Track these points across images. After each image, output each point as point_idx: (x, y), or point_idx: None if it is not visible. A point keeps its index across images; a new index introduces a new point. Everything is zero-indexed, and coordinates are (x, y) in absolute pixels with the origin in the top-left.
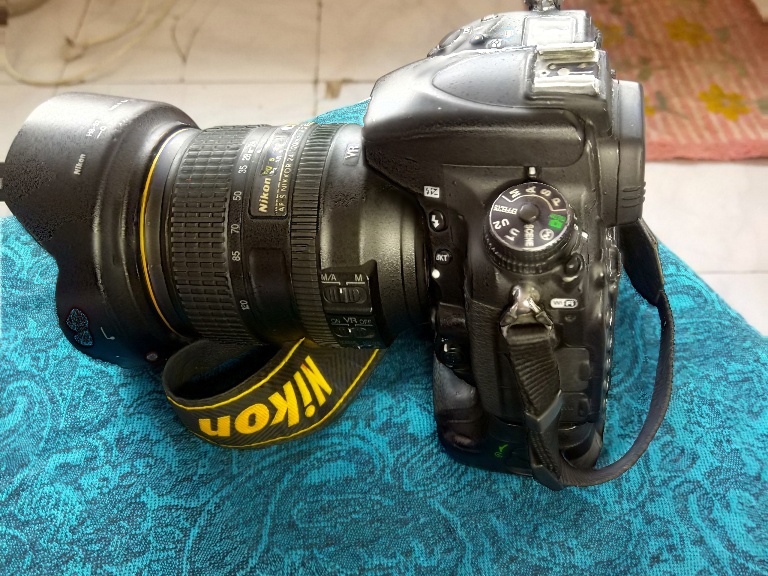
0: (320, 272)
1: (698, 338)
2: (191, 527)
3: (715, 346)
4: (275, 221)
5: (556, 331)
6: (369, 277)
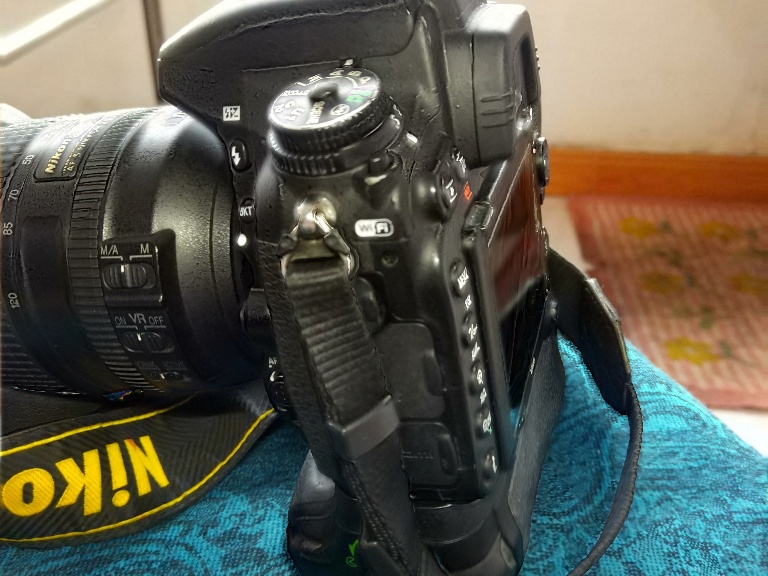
0: (100, 244)
1: (690, 465)
2: None
3: (714, 476)
4: (60, 183)
5: (375, 288)
6: (159, 248)
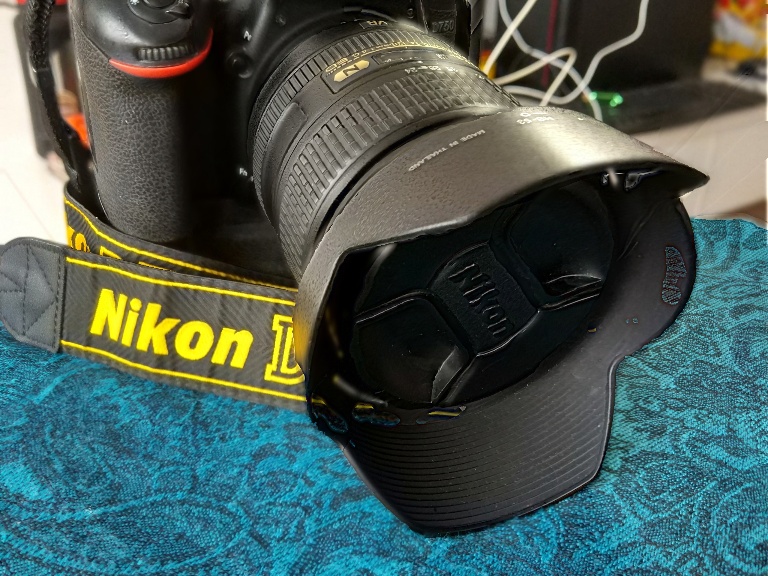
0: None
1: None
2: (649, 349)
3: None
4: None
5: None
6: None
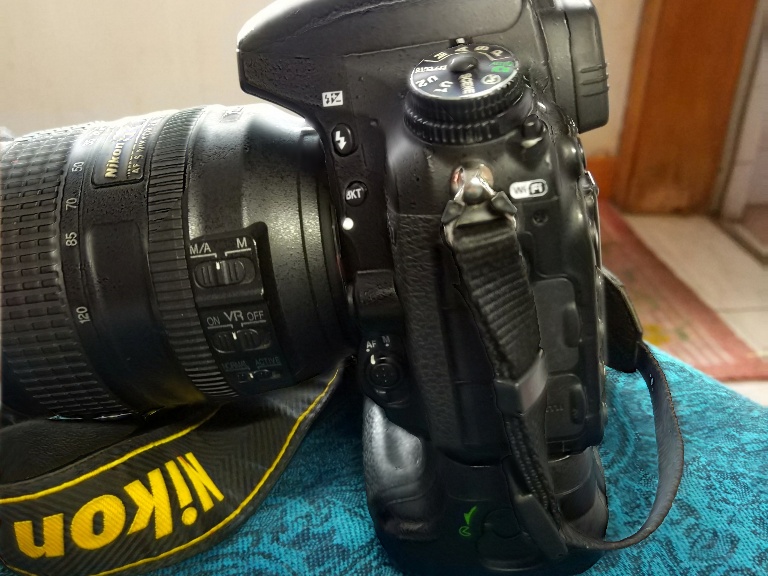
0: (188, 243)
1: (694, 410)
2: None
3: (717, 417)
4: (127, 186)
5: (523, 249)
6: (256, 241)
